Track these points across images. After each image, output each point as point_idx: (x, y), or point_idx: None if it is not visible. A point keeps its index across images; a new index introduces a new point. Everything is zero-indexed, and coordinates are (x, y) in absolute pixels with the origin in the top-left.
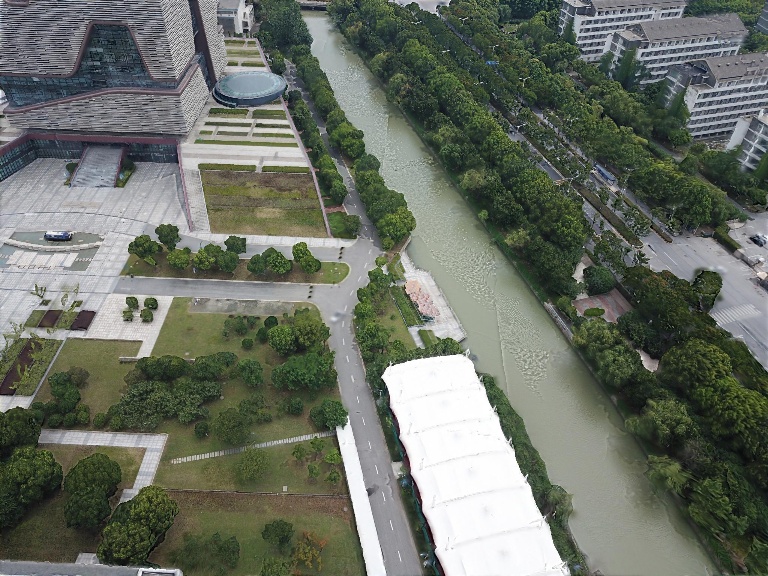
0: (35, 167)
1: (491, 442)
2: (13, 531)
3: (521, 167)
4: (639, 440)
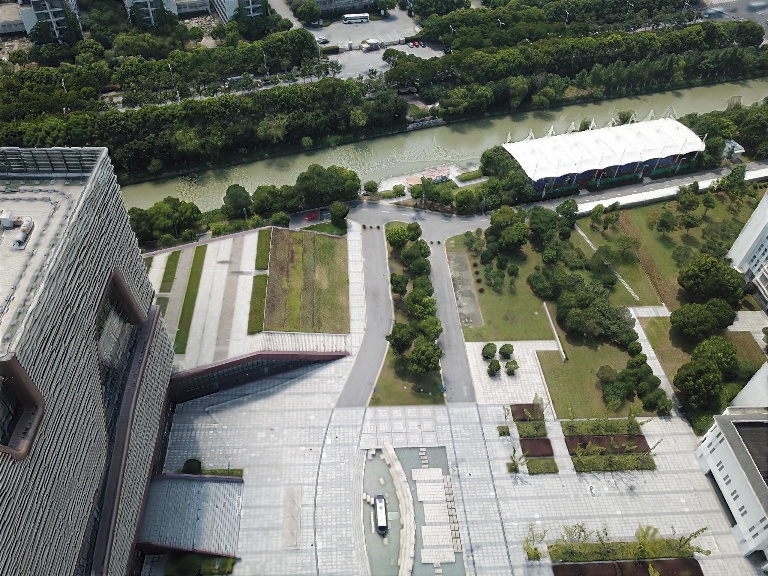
0: None
1: (569, 137)
2: None
3: (272, 96)
4: (513, 110)
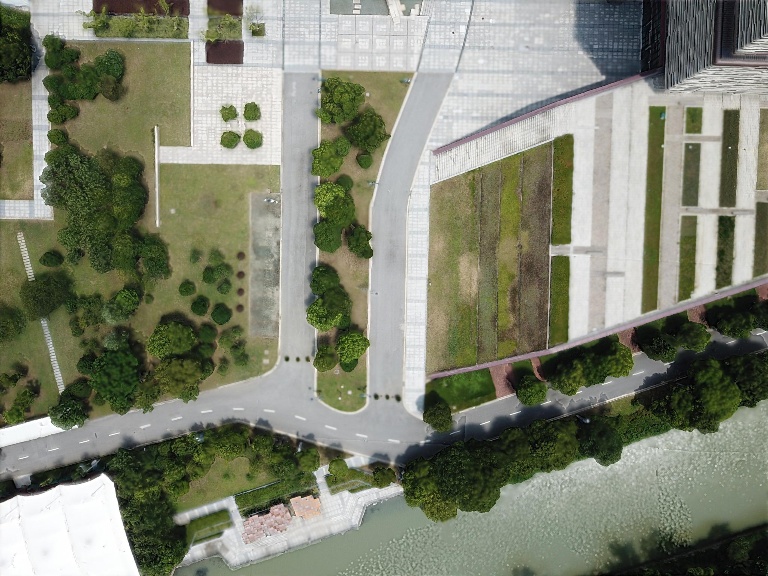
0: None
1: None
2: None
3: None
4: None
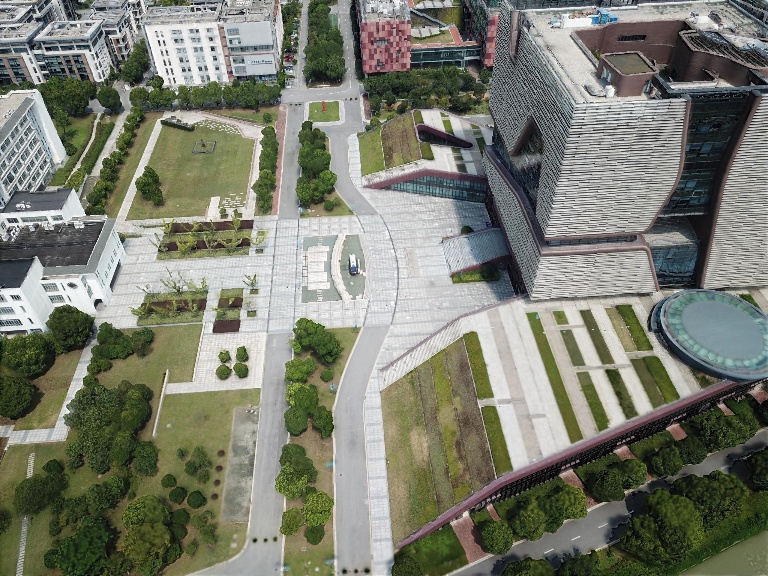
0: (467, 207)
1: None
2: (3, 366)
3: None
4: None
